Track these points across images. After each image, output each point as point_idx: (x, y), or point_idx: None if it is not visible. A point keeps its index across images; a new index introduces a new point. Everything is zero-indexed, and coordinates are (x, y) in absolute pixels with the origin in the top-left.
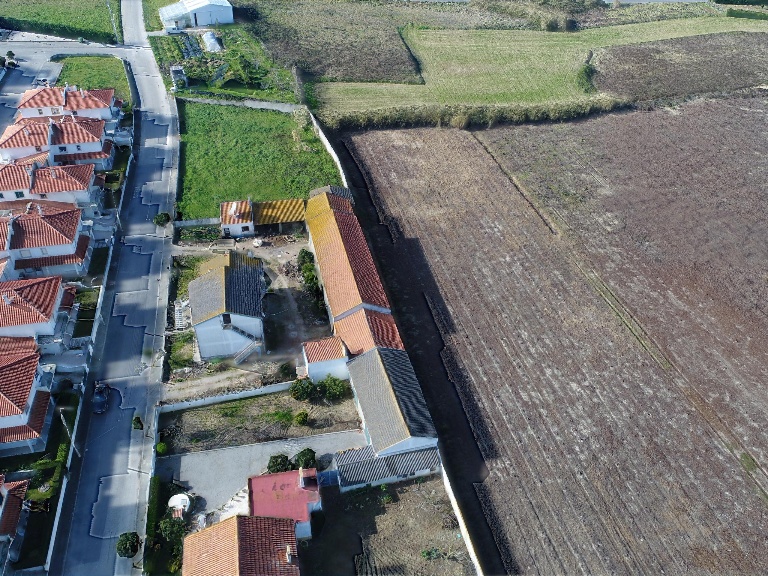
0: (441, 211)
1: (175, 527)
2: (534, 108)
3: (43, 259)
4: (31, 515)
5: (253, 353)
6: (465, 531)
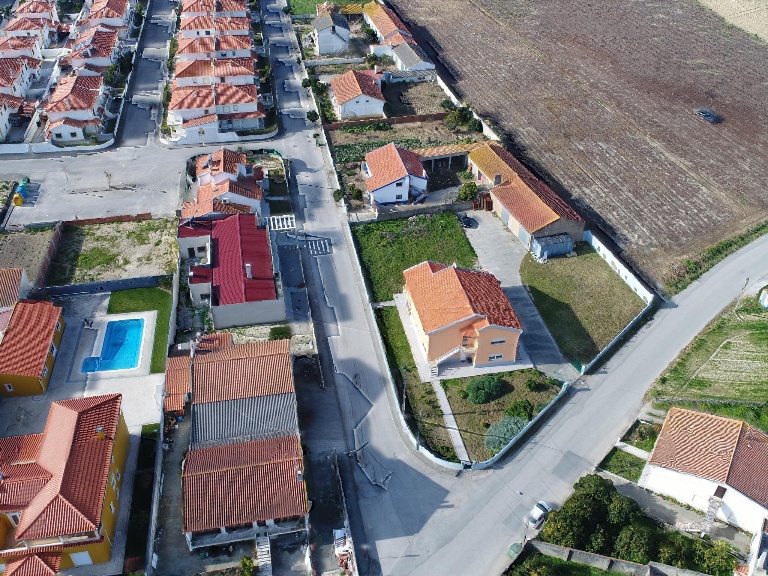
0: (438, 18)
1: None
2: None
3: None
4: None
5: (345, 50)
6: None
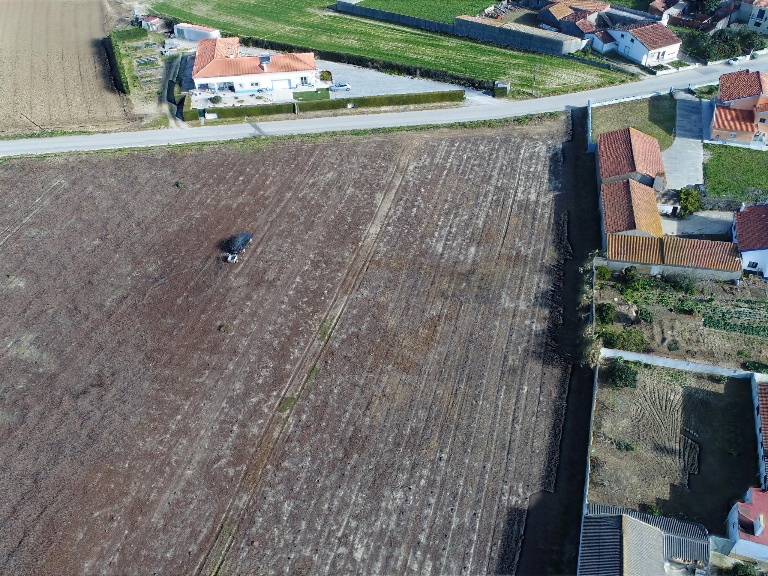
0: None
1: None
2: None
3: None
4: None
5: None
6: None
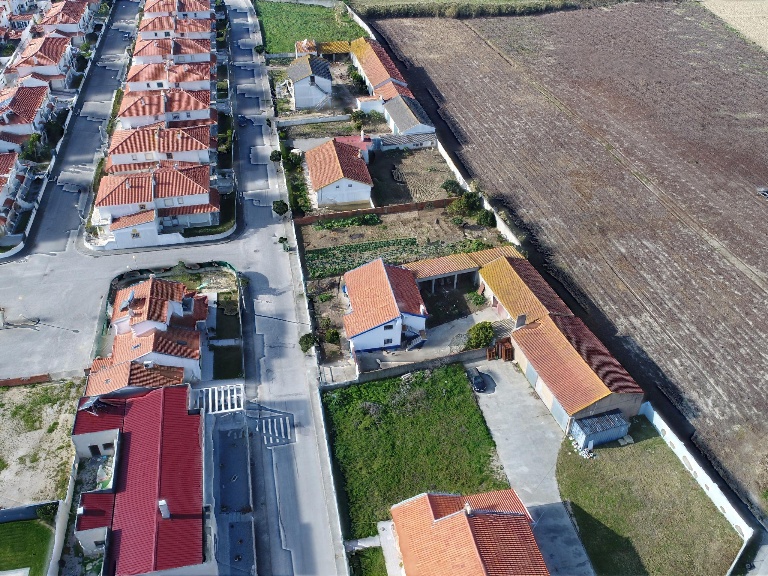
0: (438, 56)
1: (297, 156)
2: (505, 5)
3: (192, 63)
4: (219, 154)
5: (327, 103)
6: (450, 159)
